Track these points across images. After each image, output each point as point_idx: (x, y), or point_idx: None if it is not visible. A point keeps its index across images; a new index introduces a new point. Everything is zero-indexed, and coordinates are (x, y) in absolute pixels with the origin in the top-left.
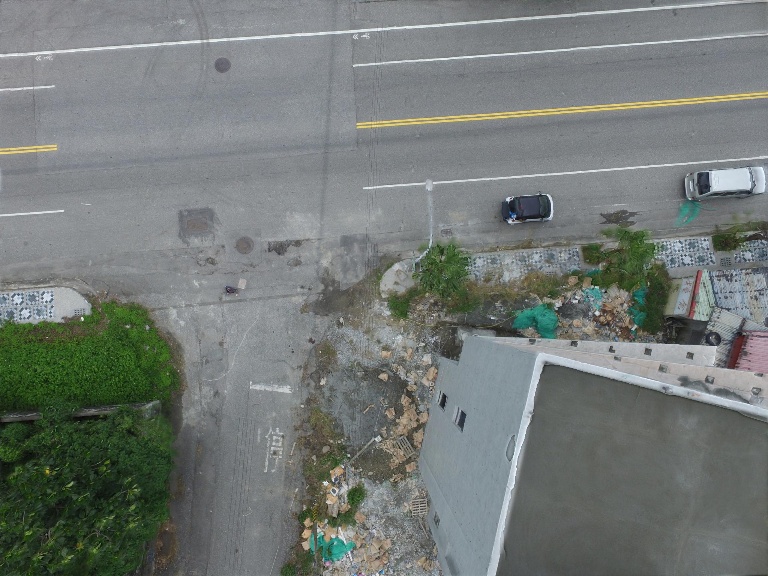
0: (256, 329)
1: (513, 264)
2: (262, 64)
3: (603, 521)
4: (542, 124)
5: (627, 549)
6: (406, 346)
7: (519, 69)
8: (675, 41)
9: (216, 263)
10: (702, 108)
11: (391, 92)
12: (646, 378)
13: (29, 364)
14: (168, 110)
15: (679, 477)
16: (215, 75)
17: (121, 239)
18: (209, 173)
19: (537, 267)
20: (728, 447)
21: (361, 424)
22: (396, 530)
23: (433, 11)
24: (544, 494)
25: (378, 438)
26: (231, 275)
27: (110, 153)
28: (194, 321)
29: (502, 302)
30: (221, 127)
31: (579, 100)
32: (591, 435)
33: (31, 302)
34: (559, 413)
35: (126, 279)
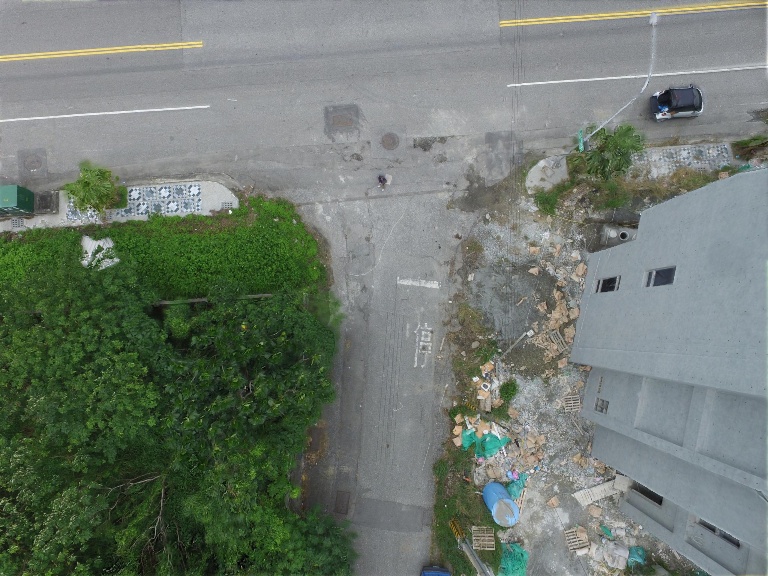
0: (403, 224)
1: (661, 161)
2: None
3: None
4: (686, 22)
5: None
6: (554, 242)
7: None
8: None
9: (361, 159)
10: None
11: None
12: None
13: (182, 253)
14: (312, 8)
15: None
16: None
17: (267, 134)
18: (354, 70)
19: (685, 163)
20: None
21: (514, 317)
22: (549, 426)
23: None
24: None
25: (531, 332)
26: (377, 171)
27: (255, 50)
28: (340, 216)
29: (650, 199)
30: (365, 25)
31: None
32: None
33: (178, 195)
34: None
35: (272, 174)
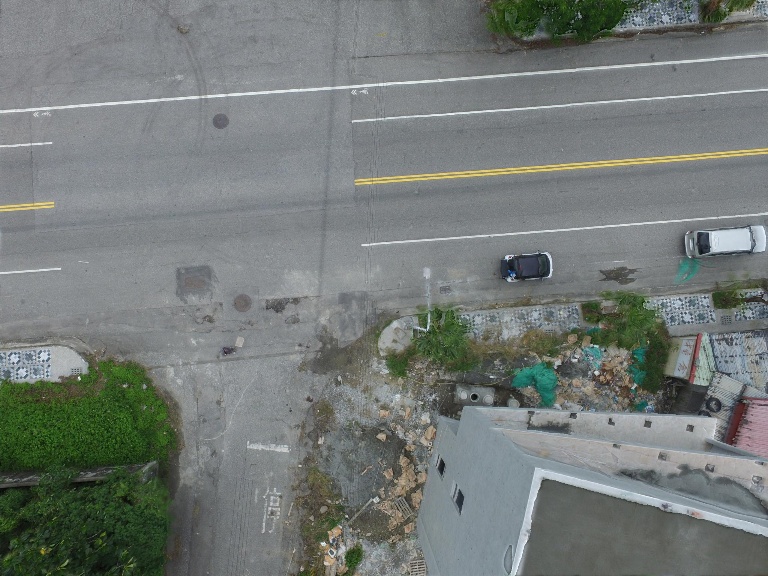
0: (254, 388)
1: (512, 322)
2: (260, 120)
3: None
4: (541, 180)
5: None
6: (404, 405)
7: (518, 125)
8: (675, 97)
9: (214, 321)
10: (702, 164)
11: (390, 148)
12: (645, 495)
13: (25, 426)
14: (166, 167)
15: None
16: (213, 131)
17: (118, 297)
18: (207, 230)
19: (536, 325)
20: (728, 558)
21: (359, 485)
22: None
23: (432, 66)
24: None
25: (376, 499)
26: (229, 333)
27: (108, 210)
28: (191, 380)
29: (501, 360)
30: (219, 184)
31: (578, 156)
32: (589, 545)
33: (28, 361)
34: (557, 522)
35: (123, 337)
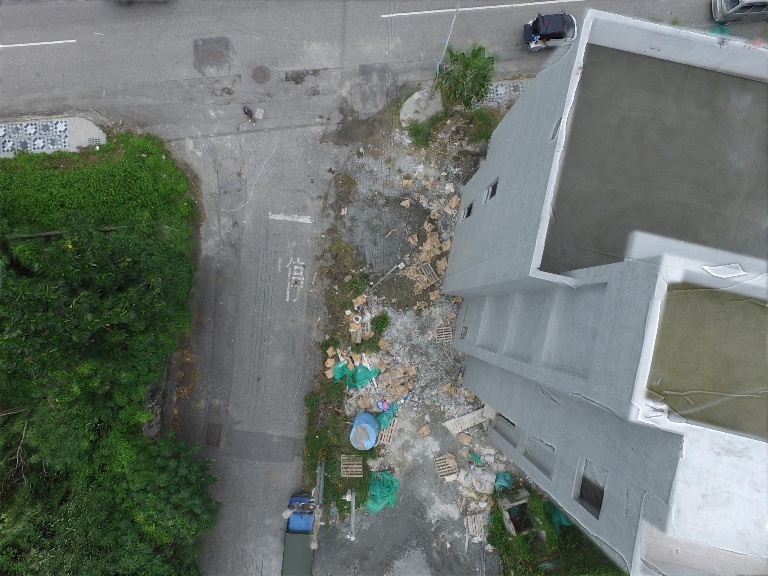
0: (275, 159)
1: None
2: None
3: (653, 201)
4: None
5: (678, 229)
6: (428, 175)
7: None
8: None
9: (232, 93)
10: None
11: None
12: (700, 34)
13: (45, 188)
14: None
15: (731, 157)
16: None
17: (135, 69)
18: (223, 1)
19: None
20: None
21: (384, 249)
22: (420, 357)
23: None
24: (592, 175)
25: (401, 264)
26: (248, 105)
27: None
28: (211, 152)
29: None
30: None
31: None
32: (639, 117)
33: (45, 132)
34: (606, 96)
35: (141, 109)
